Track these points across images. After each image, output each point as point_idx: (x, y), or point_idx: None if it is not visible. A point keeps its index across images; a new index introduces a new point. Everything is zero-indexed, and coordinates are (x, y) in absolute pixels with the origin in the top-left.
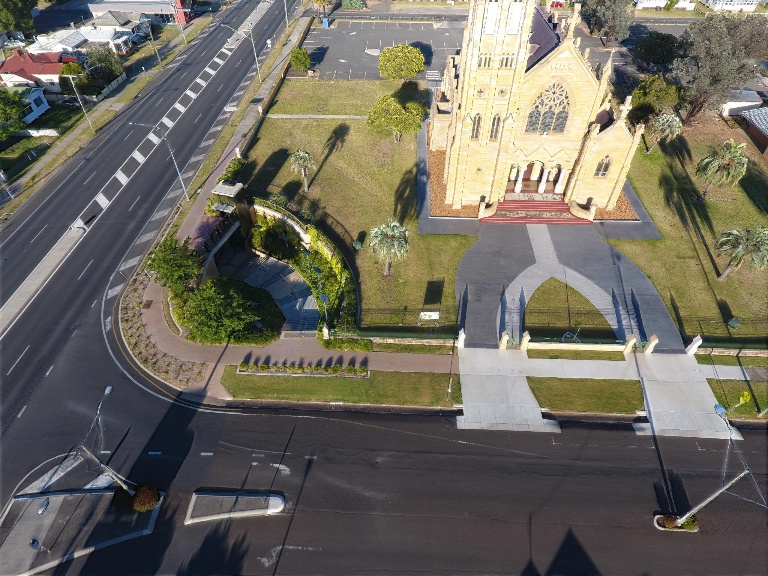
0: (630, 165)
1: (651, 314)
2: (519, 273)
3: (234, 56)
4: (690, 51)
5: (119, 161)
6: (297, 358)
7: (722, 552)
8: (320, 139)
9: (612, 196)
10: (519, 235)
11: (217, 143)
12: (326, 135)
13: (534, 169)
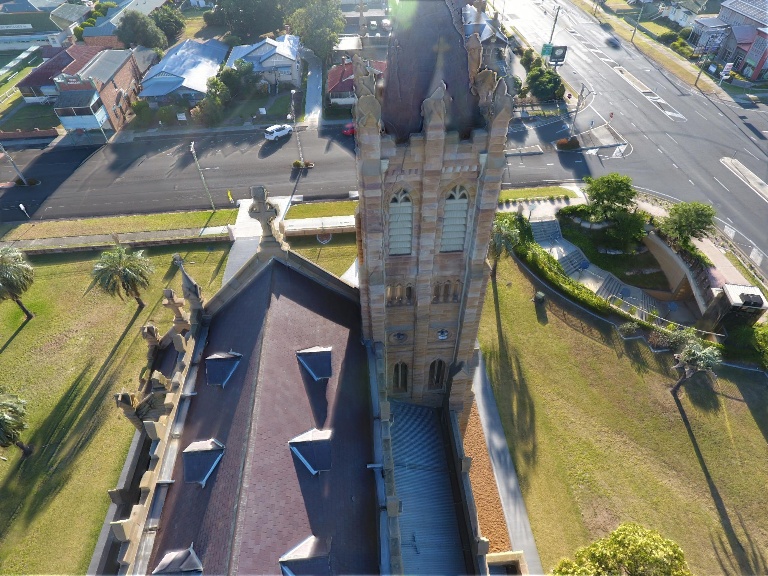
0: None
1: None
2: None
3: None
4: None
5: None
6: None
7: (287, 161)
8: None
9: None
10: None
11: None
12: None
13: None
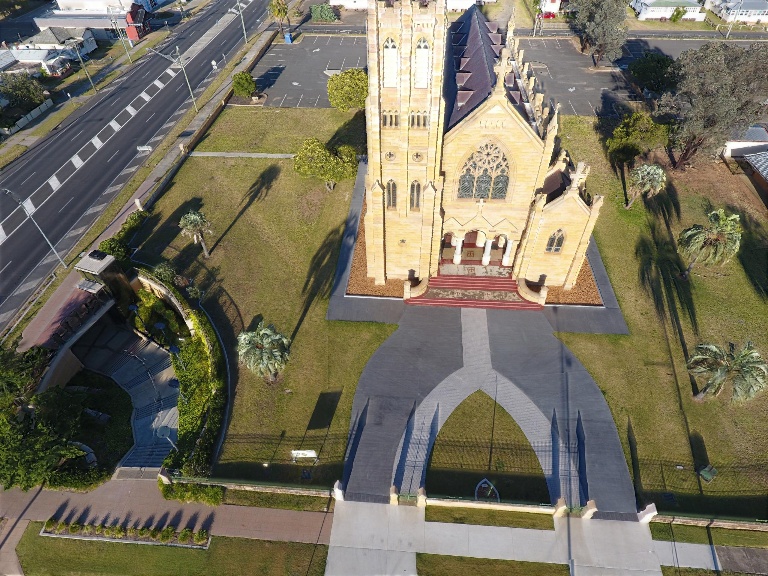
0: (601, 227)
1: (599, 453)
2: (438, 382)
3: (177, 78)
4: (681, 85)
5: (5, 213)
6: (123, 513)
7: None
8: (243, 185)
9: (569, 275)
10: (449, 324)
11: (124, 189)
12: (251, 179)
13: (479, 234)
